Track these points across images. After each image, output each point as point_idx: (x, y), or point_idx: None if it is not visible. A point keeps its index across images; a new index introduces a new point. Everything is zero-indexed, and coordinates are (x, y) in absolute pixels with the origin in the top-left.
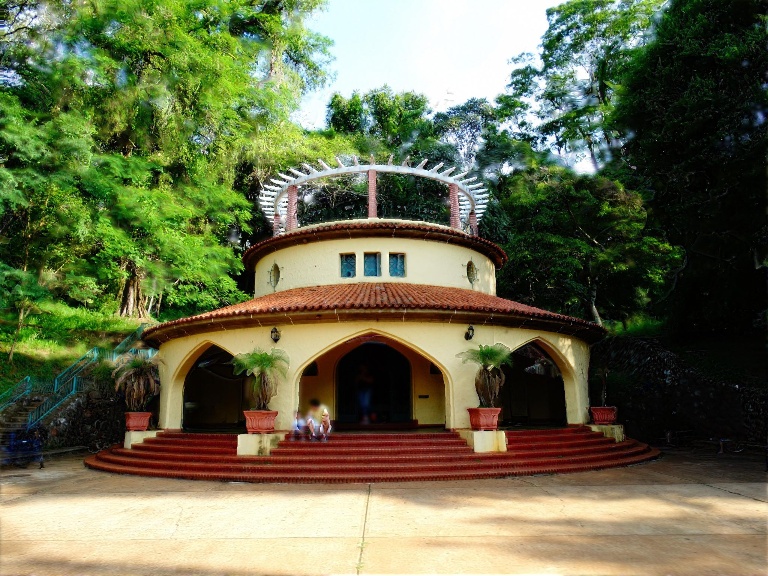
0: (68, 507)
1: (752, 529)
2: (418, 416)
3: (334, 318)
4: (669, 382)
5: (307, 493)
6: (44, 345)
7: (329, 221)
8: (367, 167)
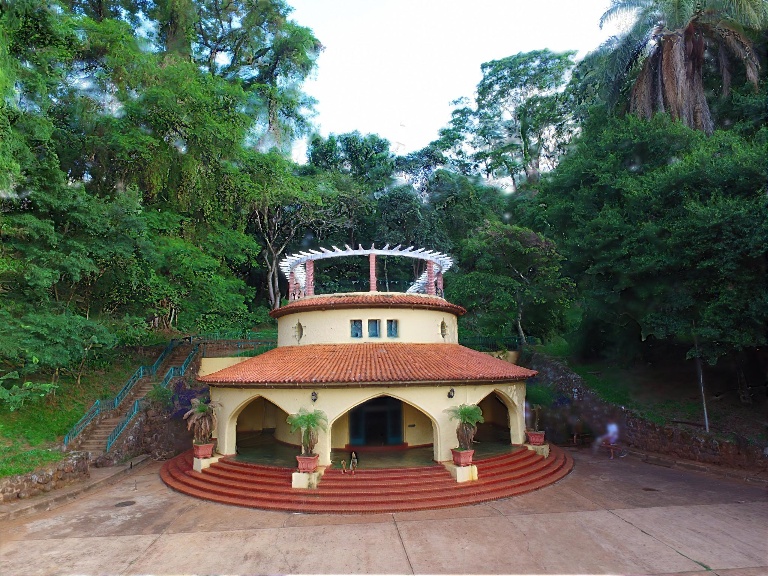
0: (202, 554)
1: (644, 569)
2: (408, 440)
3: (358, 386)
4: (576, 397)
5: (356, 529)
6: (100, 366)
7: (309, 238)
8: (369, 251)
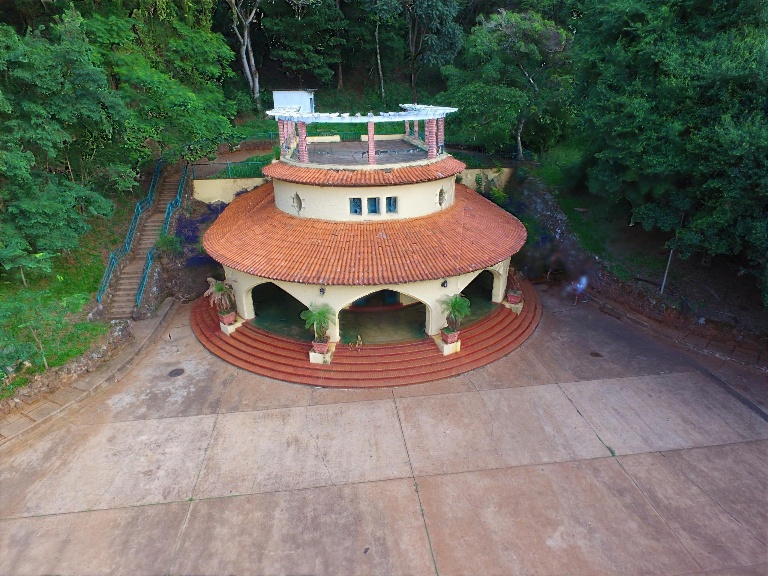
0: (255, 439)
1: (569, 455)
2: (403, 301)
3: None
4: (558, 238)
5: (365, 408)
6: None
7: None
8: (367, 119)
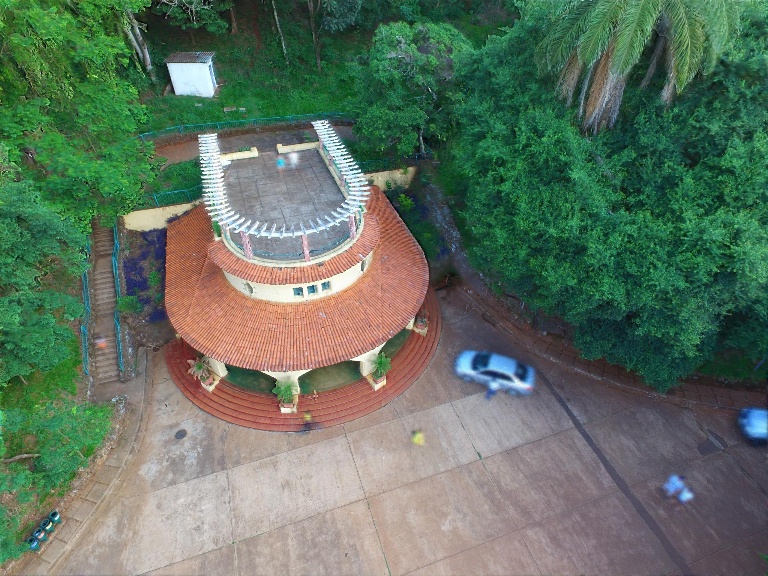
0: (260, 487)
1: (456, 463)
2: None
3: None
4: (453, 251)
5: (327, 446)
6: None
7: None
8: (300, 233)
